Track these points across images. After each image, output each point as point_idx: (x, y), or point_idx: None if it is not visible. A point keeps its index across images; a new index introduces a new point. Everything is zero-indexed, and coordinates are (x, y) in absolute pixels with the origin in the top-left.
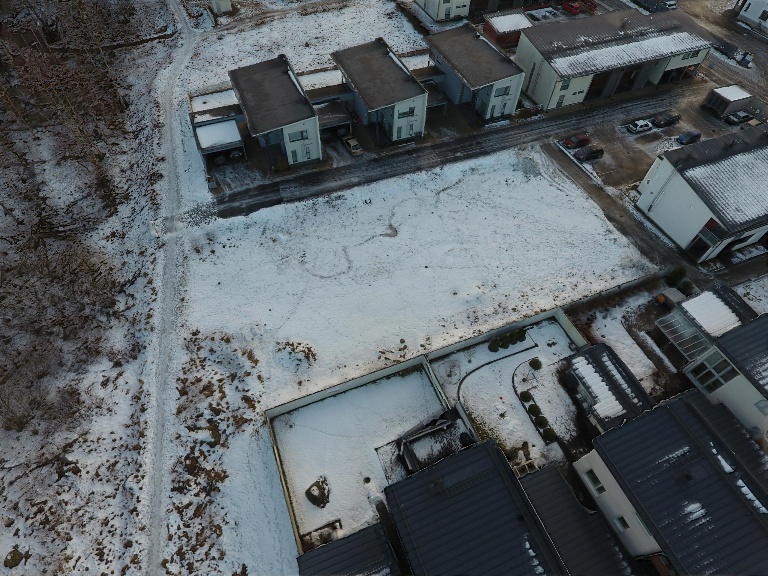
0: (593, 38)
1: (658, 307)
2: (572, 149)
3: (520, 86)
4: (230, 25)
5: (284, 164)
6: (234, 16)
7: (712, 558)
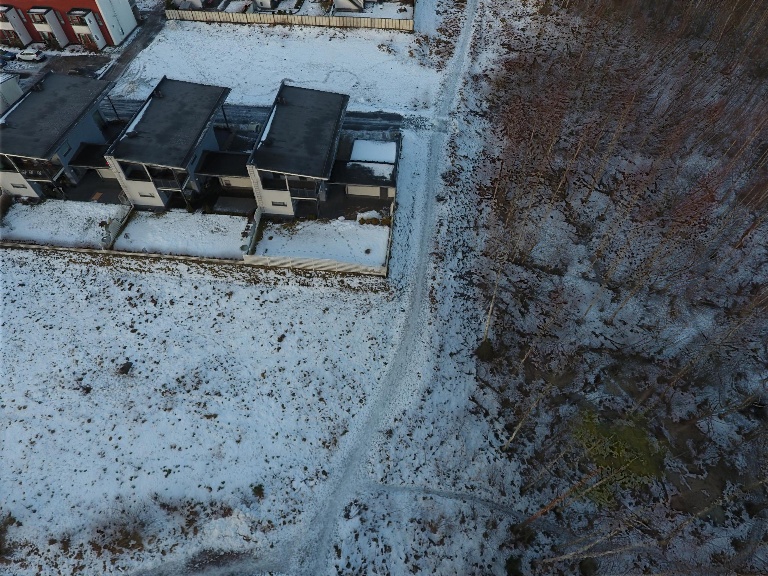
0: None
1: None
2: None
3: None
4: None
5: None
6: None
7: None
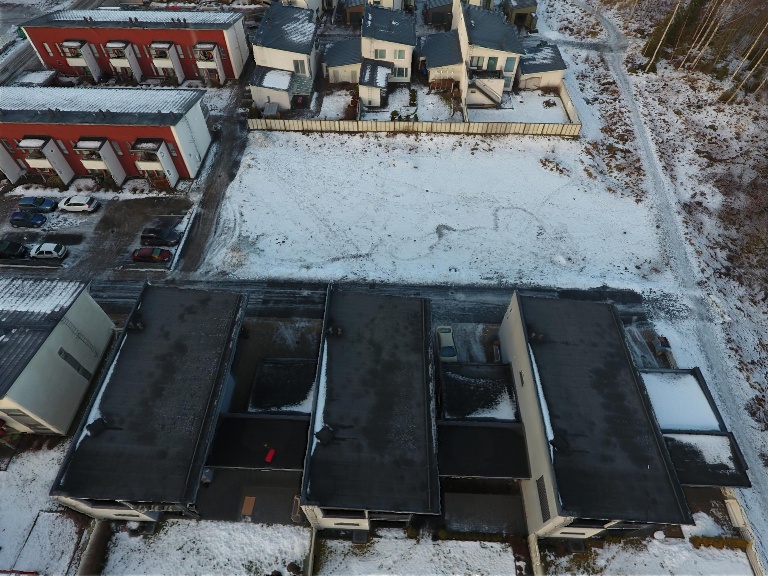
0: None
1: (284, 116)
2: None
3: None
4: None
5: None
6: None
7: (400, 18)
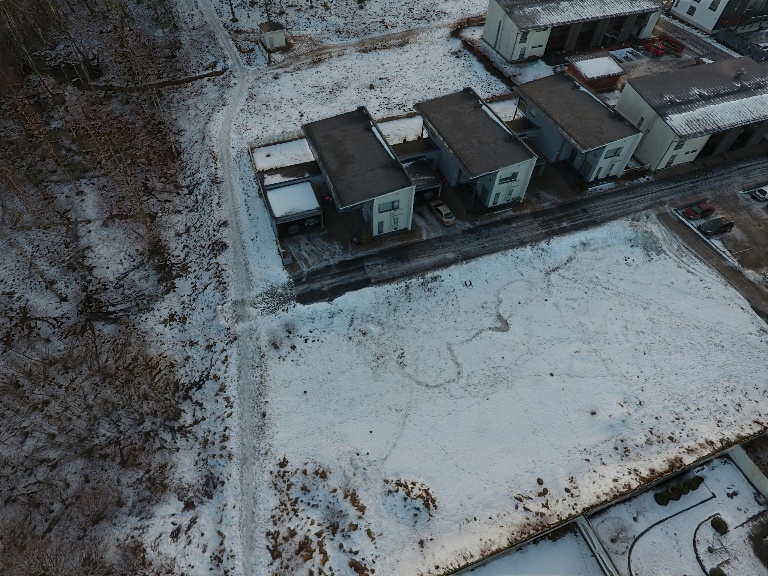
0: (708, 91)
1: None
2: (694, 220)
3: (634, 147)
4: (285, 62)
5: (369, 236)
6: (288, 52)
7: None
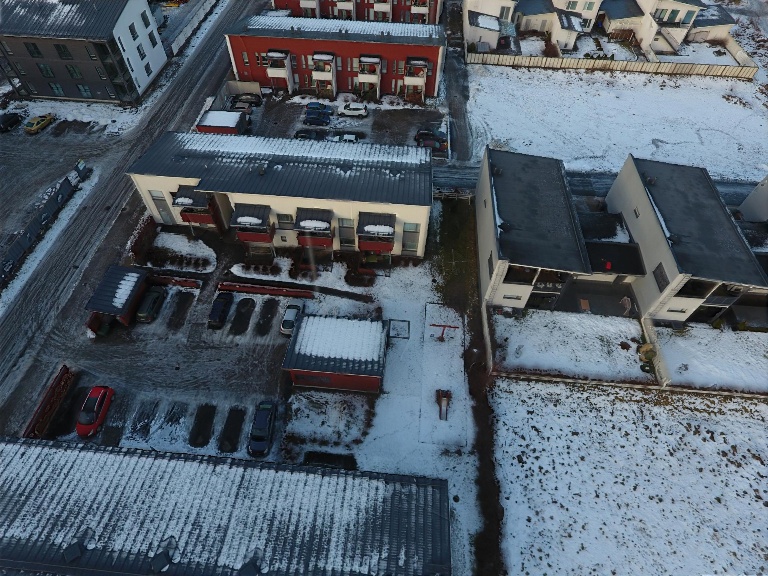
0: (331, 171)
1: None
2: None
3: None
4: None
5: None
6: None
7: None
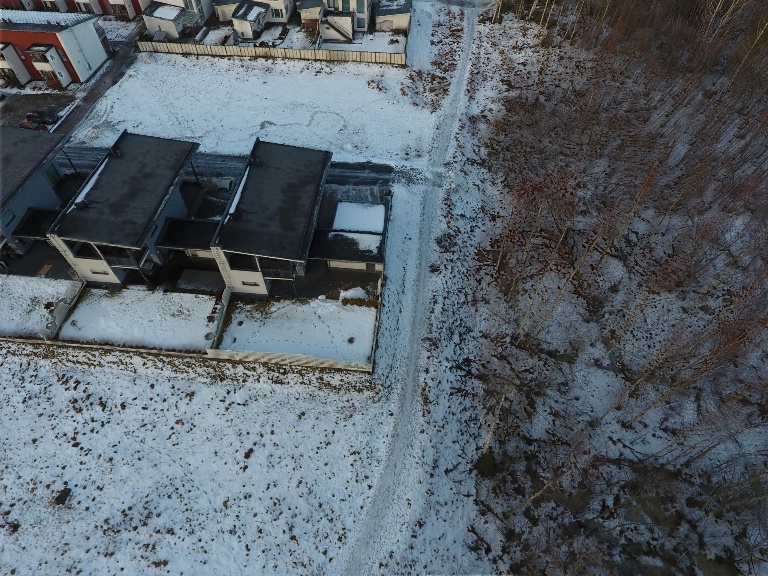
0: None
1: (172, 42)
2: None
3: None
4: None
5: None
6: None
7: None
